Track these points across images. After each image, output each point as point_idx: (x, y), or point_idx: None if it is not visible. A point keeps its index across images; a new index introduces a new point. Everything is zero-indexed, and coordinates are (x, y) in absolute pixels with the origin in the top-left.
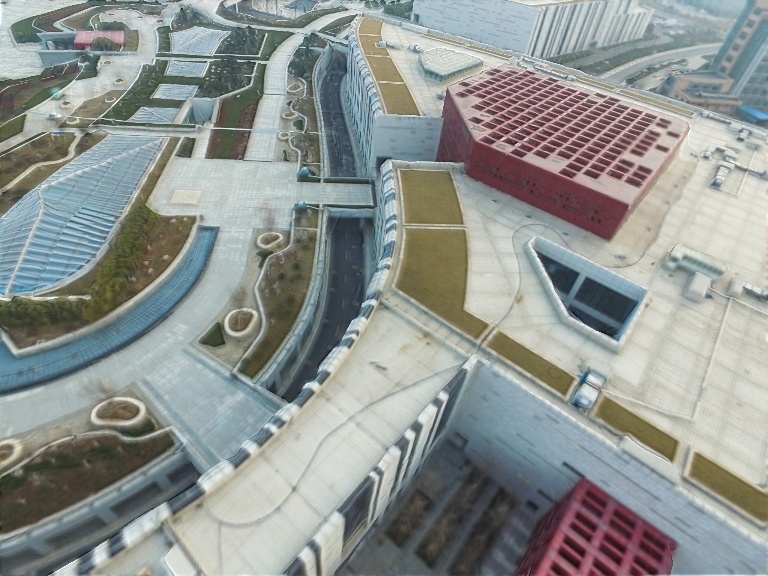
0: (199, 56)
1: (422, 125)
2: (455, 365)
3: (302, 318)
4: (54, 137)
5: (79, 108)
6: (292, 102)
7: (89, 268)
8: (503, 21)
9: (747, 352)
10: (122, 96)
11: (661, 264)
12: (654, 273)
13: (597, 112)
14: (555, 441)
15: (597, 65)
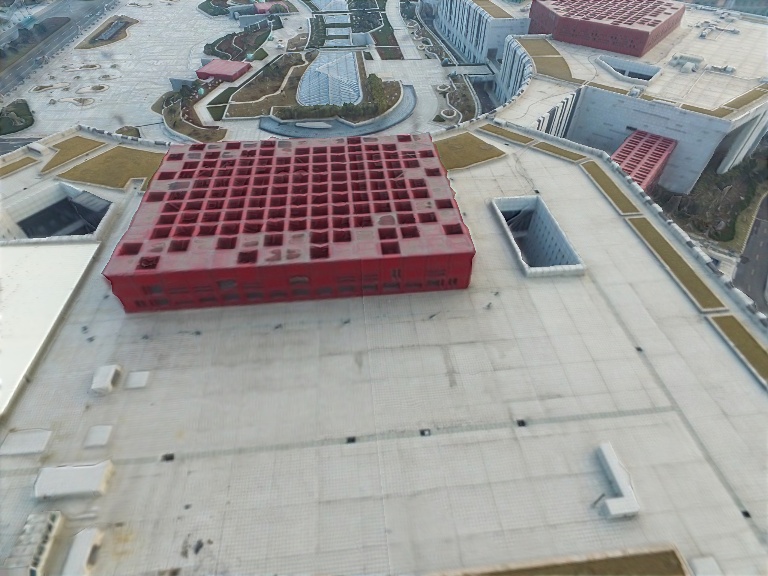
0: (340, 12)
1: (518, 24)
2: None
3: (478, 113)
4: (292, 55)
5: (288, 43)
6: (414, 32)
7: (361, 100)
8: None
9: (711, 84)
10: (310, 35)
11: (669, 63)
12: (665, 66)
13: (627, 2)
14: (622, 115)
15: None
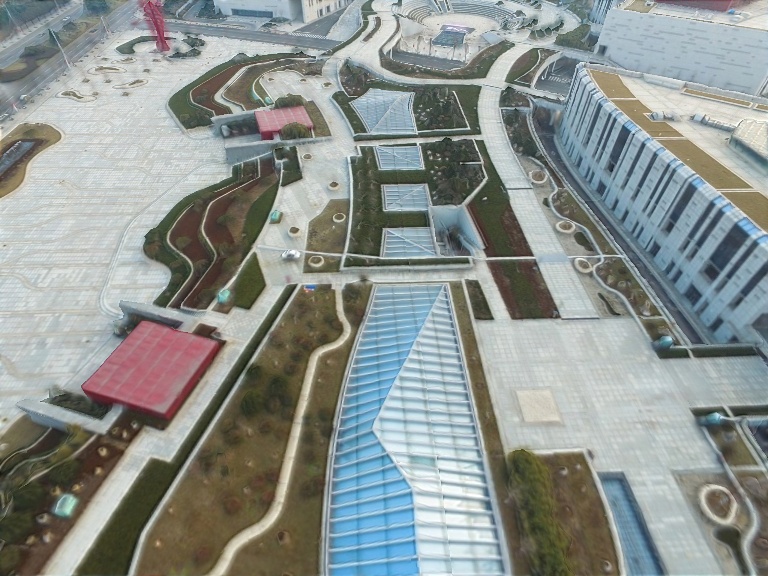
0: (403, 136)
1: None
2: None
3: None
4: (314, 297)
5: (309, 235)
6: (549, 200)
7: None
8: (732, 52)
9: None
10: (351, 211)
11: None
12: None
13: None
14: None
15: None
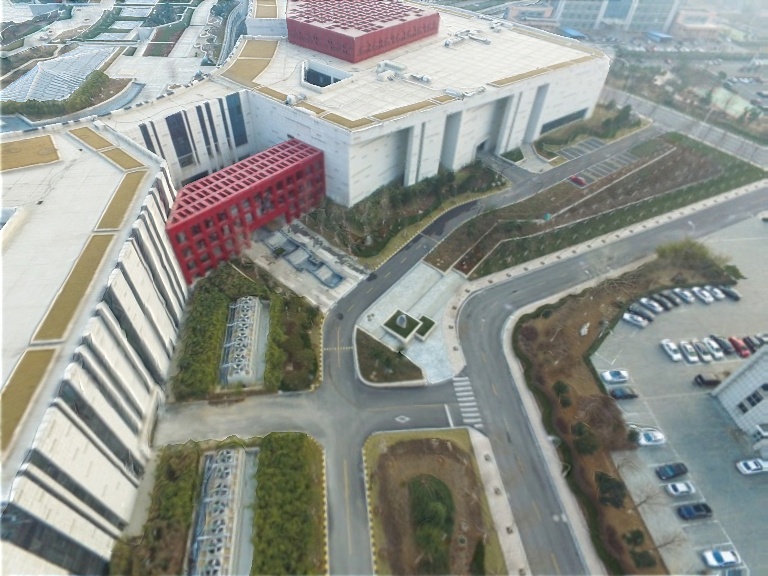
0: (145, 5)
1: (277, 25)
2: None
3: None
4: (44, 47)
5: (60, 35)
6: (209, 29)
7: (68, 97)
8: None
9: None
10: (89, 27)
11: (376, 70)
12: None
13: (379, 7)
14: (280, 122)
15: (466, 7)
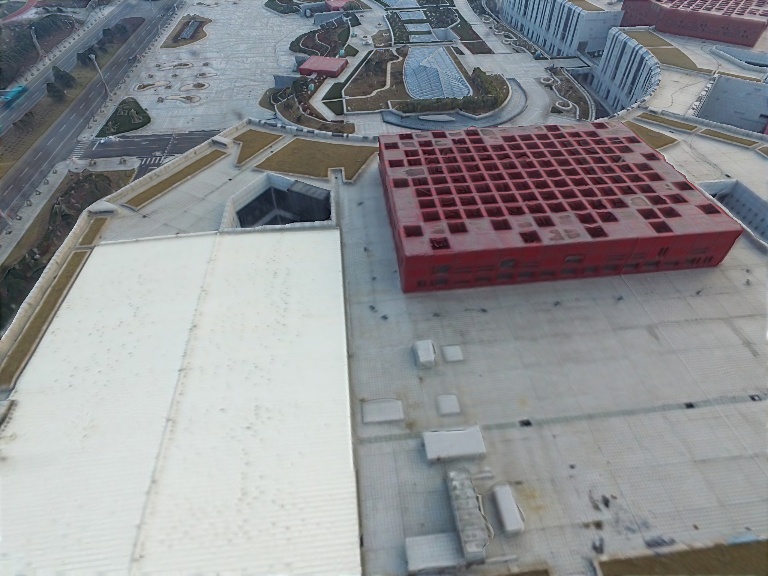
0: (412, 8)
1: (611, 17)
2: (707, 79)
3: (591, 104)
4: (384, 50)
5: (373, 39)
6: (492, 27)
7: (472, 93)
8: None
9: None
10: (392, 31)
11: None
12: None
13: None
14: (757, 103)
15: None
